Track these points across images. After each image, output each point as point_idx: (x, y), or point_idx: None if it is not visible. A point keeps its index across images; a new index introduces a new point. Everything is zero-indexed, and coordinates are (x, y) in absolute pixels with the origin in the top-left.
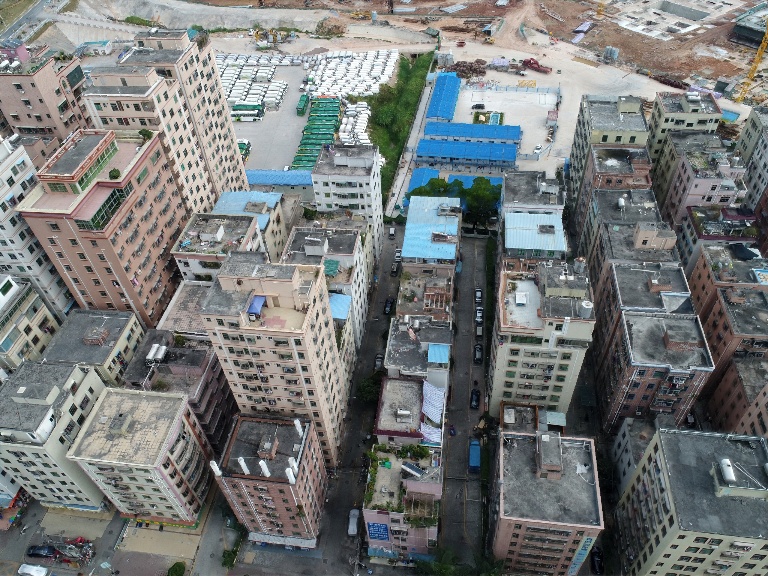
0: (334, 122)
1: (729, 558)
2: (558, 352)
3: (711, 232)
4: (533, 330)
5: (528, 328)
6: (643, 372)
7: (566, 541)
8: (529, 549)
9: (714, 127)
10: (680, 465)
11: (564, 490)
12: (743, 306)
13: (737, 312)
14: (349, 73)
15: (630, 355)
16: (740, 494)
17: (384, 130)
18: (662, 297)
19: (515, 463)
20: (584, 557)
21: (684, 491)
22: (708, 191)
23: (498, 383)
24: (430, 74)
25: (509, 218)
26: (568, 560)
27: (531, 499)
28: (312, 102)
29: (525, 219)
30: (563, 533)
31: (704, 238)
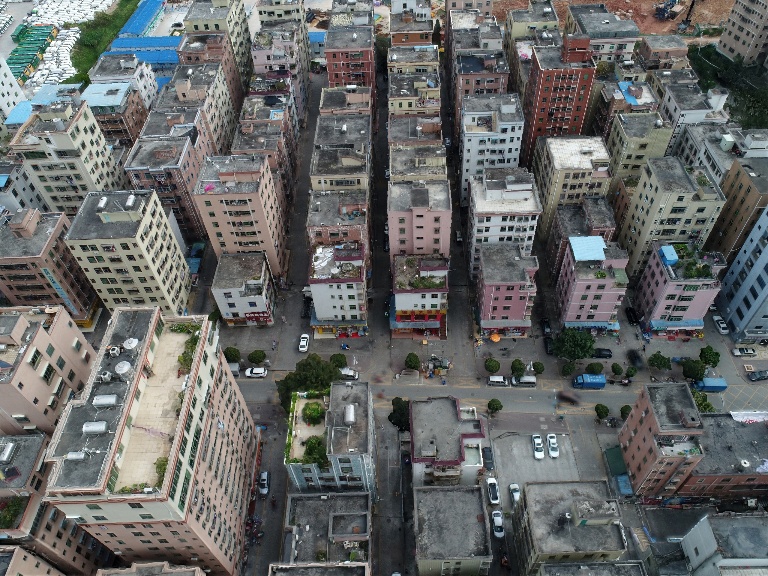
0: (40, 44)
1: (116, 262)
2: (64, 164)
3: (256, 89)
4: (33, 146)
5: (28, 144)
6: (138, 176)
7: (34, 275)
8: (24, 291)
9: (299, 16)
10: (92, 210)
11: (31, 242)
12: (251, 134)
13: (244, 139)
14: (71, 4)
15: (125, 163)
16: (118, 220)
17: (90, 50)
18: (172, 127)
19: (6, 232)
20: (63, 291)
21: (85, 223)
22: (266, 61)
23: (48, 199)
24: (142, 1)
25: (89, 87)
26: (58, 297)
27: (6, 249)
28: (27, 30)
29: (101, 87)
30: (24, 267)
31: (251, 94)
